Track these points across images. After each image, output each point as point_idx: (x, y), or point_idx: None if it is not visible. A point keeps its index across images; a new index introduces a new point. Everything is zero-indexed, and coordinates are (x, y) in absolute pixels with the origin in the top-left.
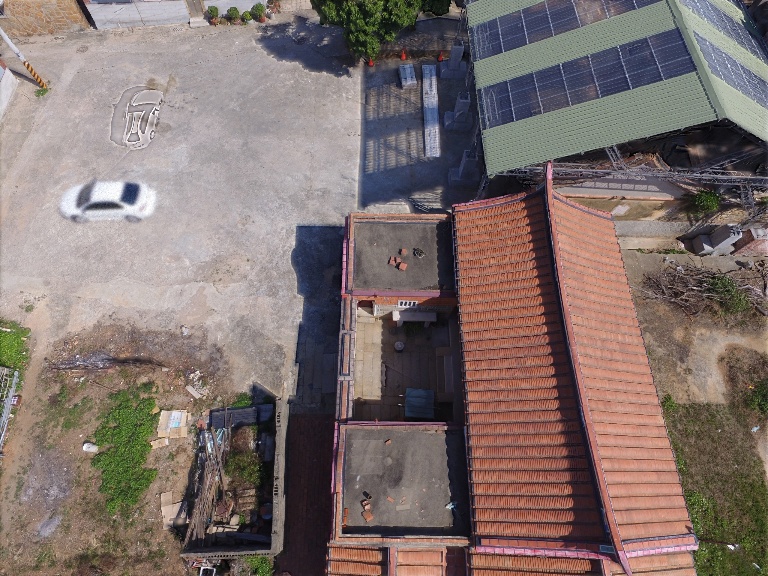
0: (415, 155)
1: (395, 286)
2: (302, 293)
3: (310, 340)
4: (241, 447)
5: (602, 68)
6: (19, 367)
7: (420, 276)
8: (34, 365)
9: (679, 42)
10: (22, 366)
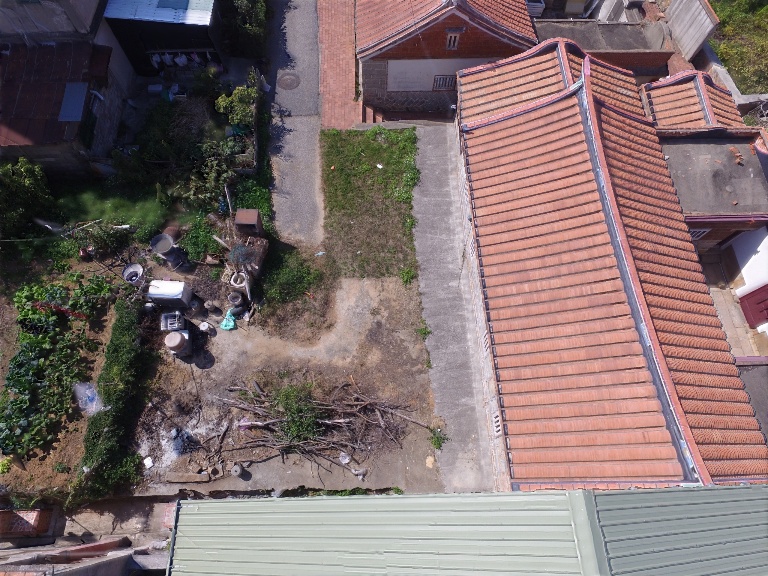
0: None
1: None
2: None
3: None
4: None
5: None
6: None
7: (767, 385)
8: None
9: None
10: None
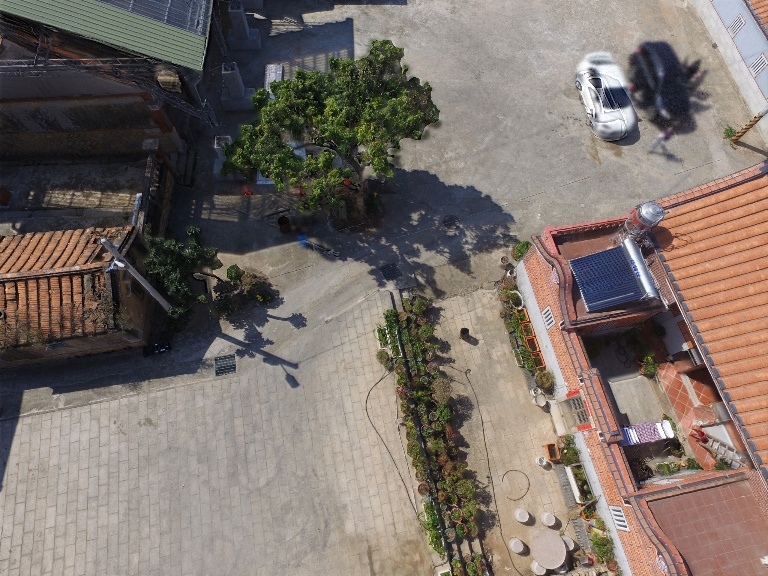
0: (294, 68)
1: None
2: None
3: None
4: None
5: None
6: None
7: None
8: None
9: None
10: None
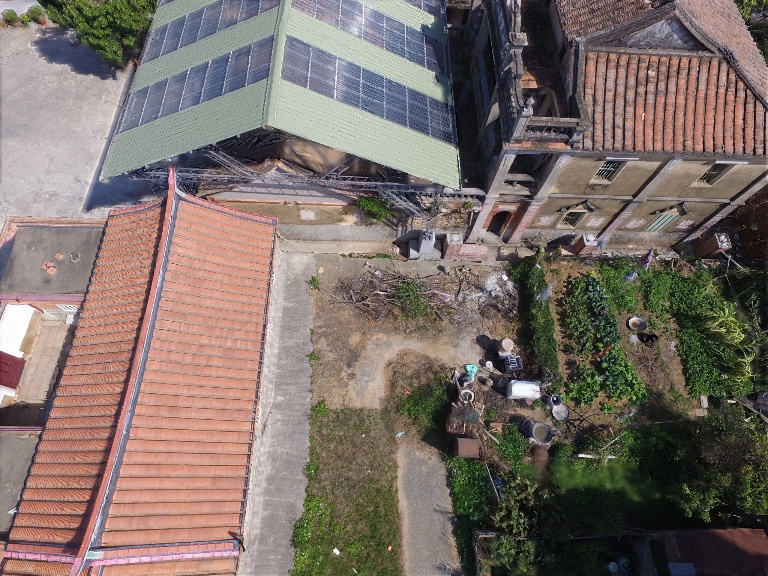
0: None
1: (40, 290)
2: None
3: None
4: None
5: (213, 74)
6: None
7: (70, 280)
8: None
9: (269, 48)
10: None
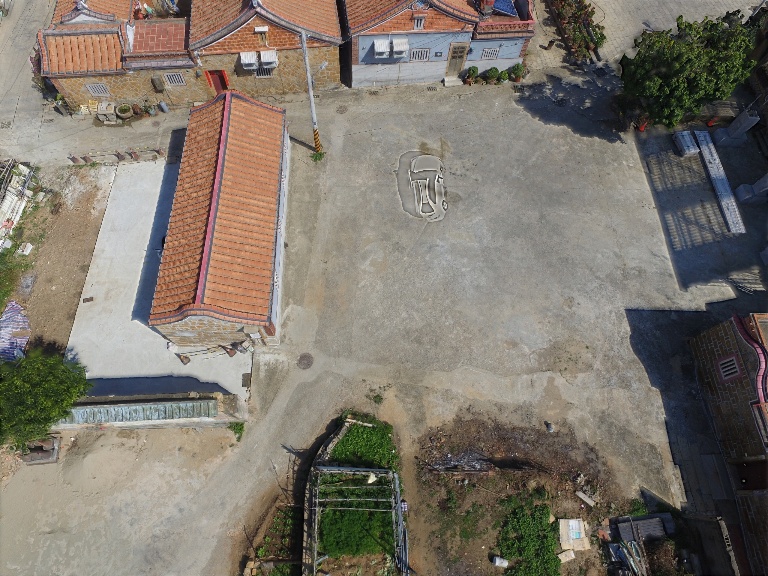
0: (718, 230)
1: None
2: (656, 385)
3: (681, 439)
4: (665, 565)
5: None
6: (394, 467)
7: None
8: (407, 465)
9: None
10: (396, 466)
